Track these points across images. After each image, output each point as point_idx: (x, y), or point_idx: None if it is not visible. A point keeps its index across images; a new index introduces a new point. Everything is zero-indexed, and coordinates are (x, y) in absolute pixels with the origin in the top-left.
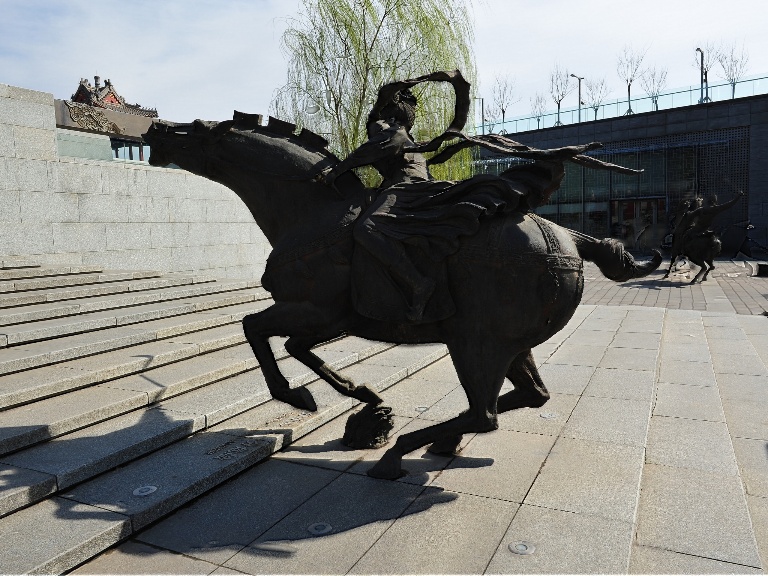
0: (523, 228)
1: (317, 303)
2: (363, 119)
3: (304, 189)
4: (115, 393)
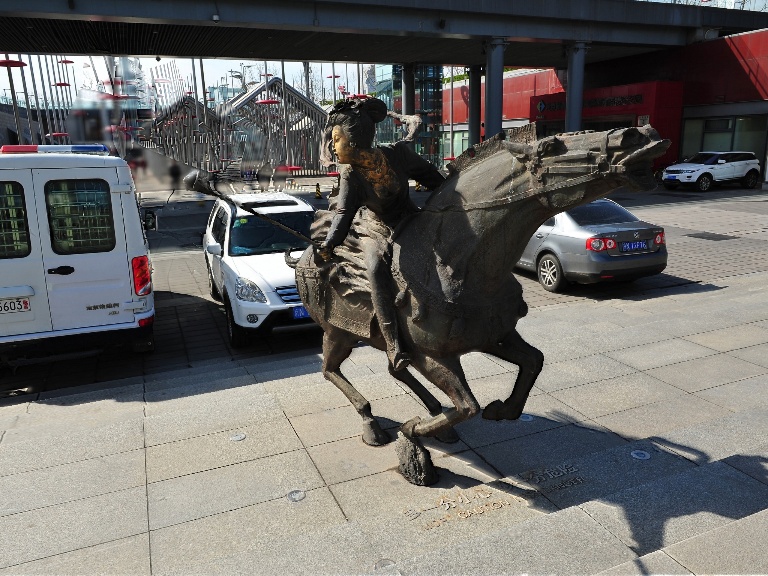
0: None
1: None
2: None
3: None
4: (718, 572)
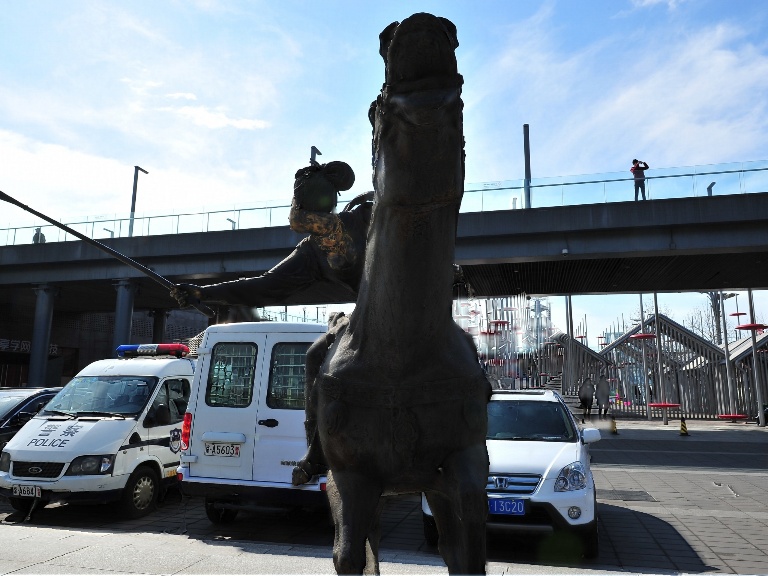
0: None
1: None
2: None
3: None
4: None
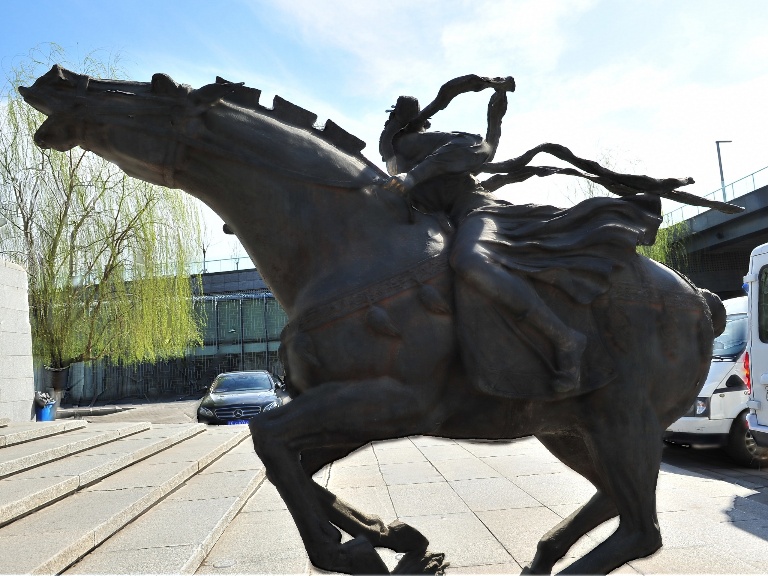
0: (658, 264)
1: (407, 378)
2: (63, 240)
3: (355, 202)
4: None
